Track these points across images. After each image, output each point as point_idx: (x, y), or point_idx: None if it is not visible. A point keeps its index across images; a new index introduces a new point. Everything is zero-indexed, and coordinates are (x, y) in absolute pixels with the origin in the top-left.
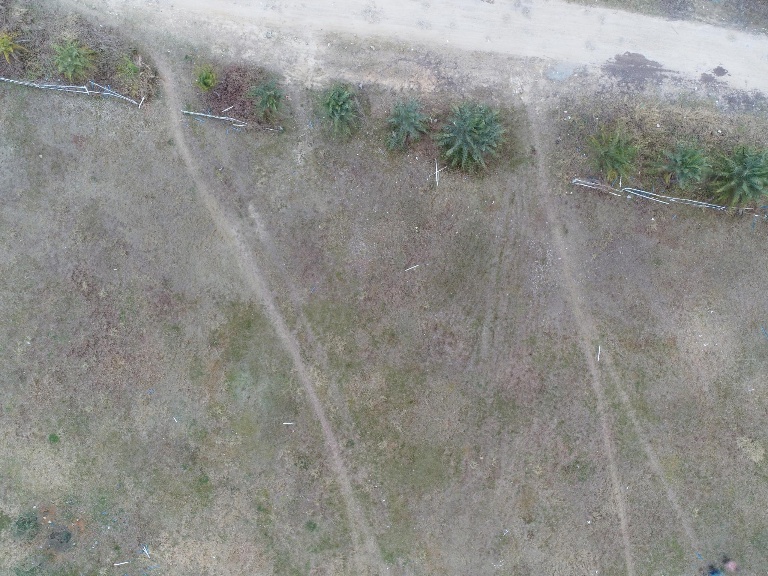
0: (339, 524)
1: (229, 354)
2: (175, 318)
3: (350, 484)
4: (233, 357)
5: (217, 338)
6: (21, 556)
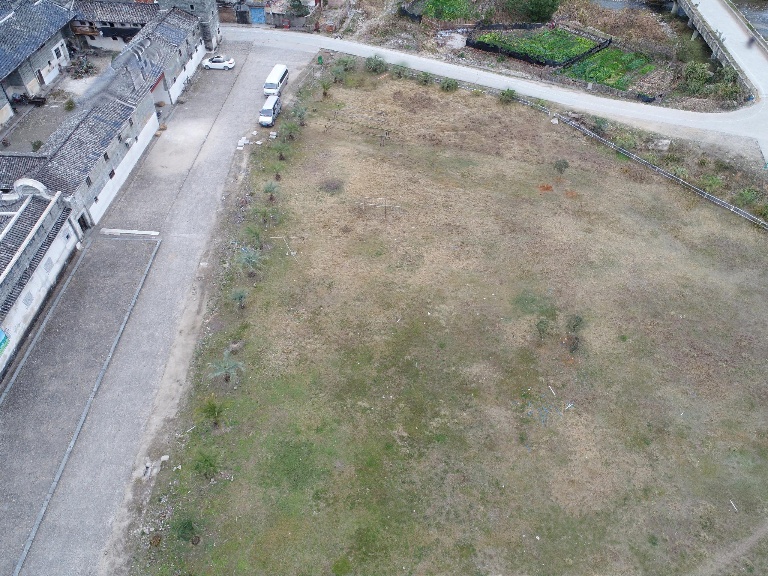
0: (668, 568)
1: (760, 447)
2: (760, 404)
3: (712, 574)
4: (759, 450)
5: (766, 436)
6: (532, 329)
